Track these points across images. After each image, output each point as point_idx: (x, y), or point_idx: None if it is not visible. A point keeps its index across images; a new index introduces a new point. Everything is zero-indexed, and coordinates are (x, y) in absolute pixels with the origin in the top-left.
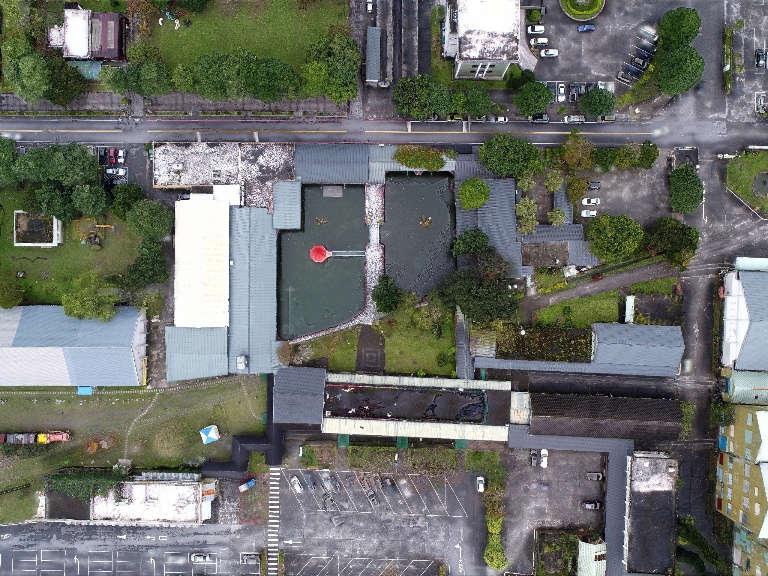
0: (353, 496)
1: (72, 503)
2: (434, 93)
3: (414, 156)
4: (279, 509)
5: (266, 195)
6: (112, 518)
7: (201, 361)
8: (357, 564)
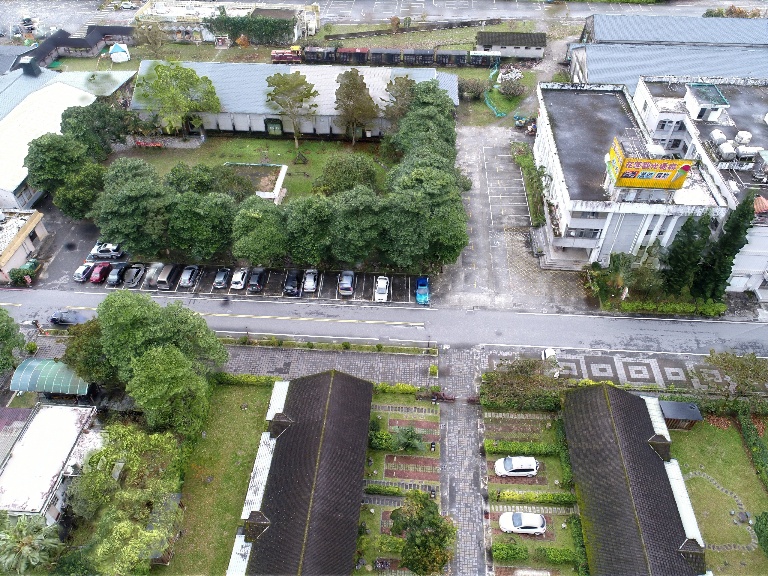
0: (7, 28)
1: (272, 15)
2: None
3: None
4: (85, 25)
5: None
6: (236, 9)
7: (86, 78)
8: (36, 4)
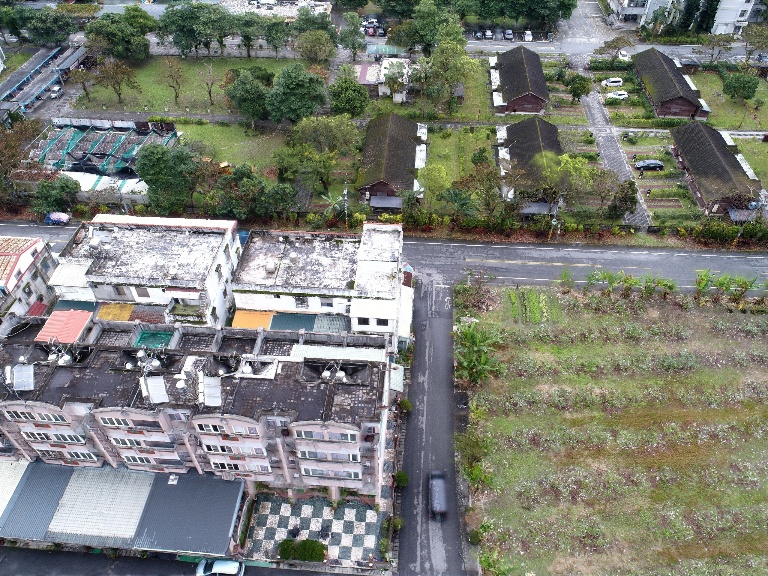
0: None
1: None
2: (30, 8)
3: (82, 8)
4: None
5: (230, 0)
6: None
7: None
8: None
